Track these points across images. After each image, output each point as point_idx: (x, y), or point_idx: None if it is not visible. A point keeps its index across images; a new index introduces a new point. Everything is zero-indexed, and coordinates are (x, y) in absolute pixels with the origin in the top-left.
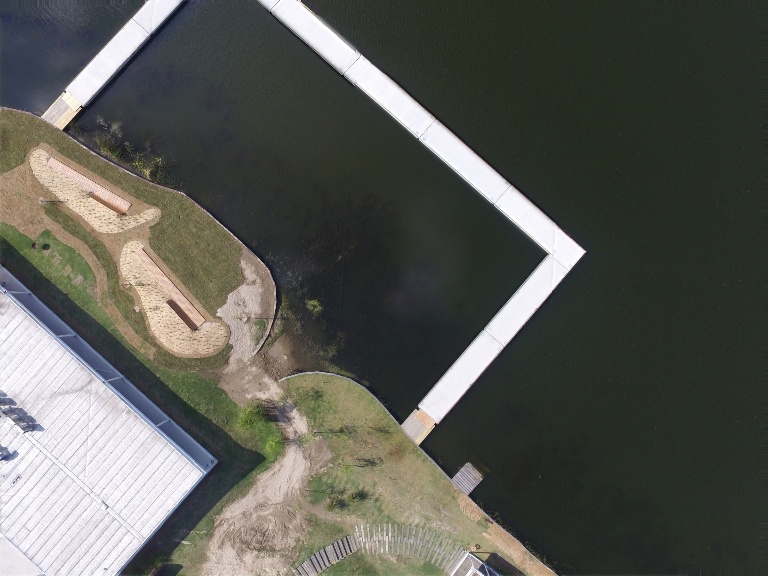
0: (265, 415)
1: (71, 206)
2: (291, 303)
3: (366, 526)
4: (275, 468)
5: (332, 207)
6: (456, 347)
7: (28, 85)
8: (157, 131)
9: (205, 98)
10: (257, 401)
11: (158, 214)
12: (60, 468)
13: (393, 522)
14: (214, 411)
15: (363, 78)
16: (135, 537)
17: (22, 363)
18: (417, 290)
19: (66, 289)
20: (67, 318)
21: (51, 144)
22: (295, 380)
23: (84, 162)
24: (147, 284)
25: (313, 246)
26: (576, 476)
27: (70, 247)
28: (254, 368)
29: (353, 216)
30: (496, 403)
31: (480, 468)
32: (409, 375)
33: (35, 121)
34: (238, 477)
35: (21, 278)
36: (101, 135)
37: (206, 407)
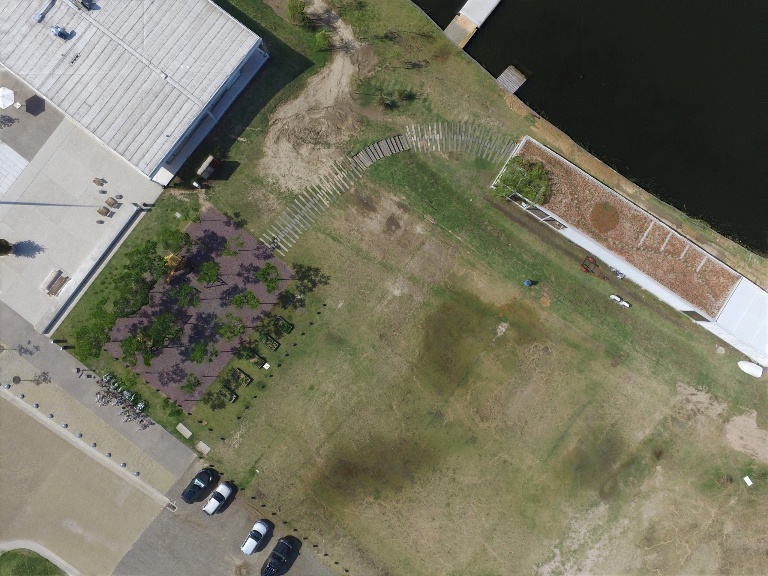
0: (311, 27)
1: None
2: None
3: (417, 126)
4: (324, 73)
5: None
6: None
7: None
8: None
9: None
10: (302, 15)
11: None
12: (118, 43)
13: (443, 120)
14: (262, 18)
15: None
16: (195, 103)
17: None
18: None
19: None
20: None
21: None
22: None
23: None
24: None
25: None
26: (616, 74)
27: None
28: None
29: None
30: (533, 10)
31: (523, 70)
32: None
33: None
34: (289, 76)
35: None
36: None
37: (254, 14)
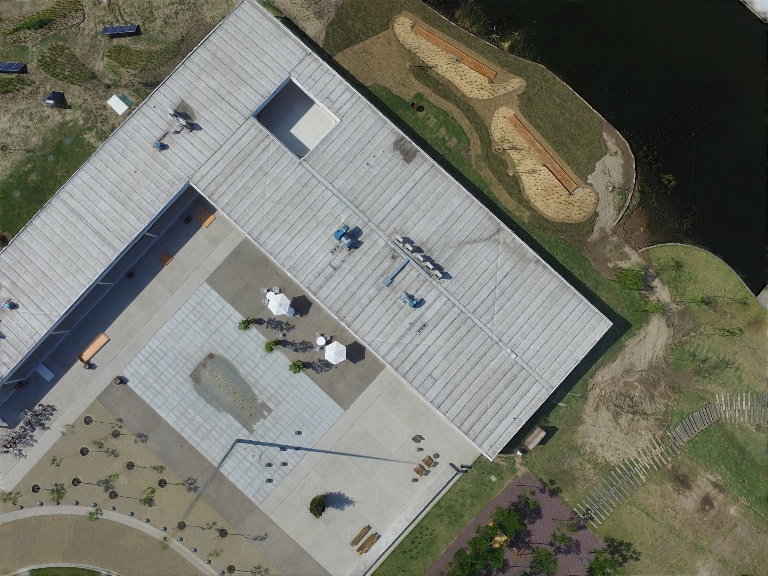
0: None
1: (440, 71)
2: (646, 177)
3: (726, 395)
4: (641, 335)
5: (684, 86)
6: None
7: None
8: (513, 6)
9: None
10: (619, 270)
11: (523, 84)
12: (468, 316)
13: (752, 391)
14: (585, 276)
15: None
16: (544, 387)
17: (429, 211)
18: (765, 169)
19: (441, 151)
20: None
21: (413, 13)
22: (655, 251)
23: (447, 31)
24: (521, 149)
25: (667, 122)
26: None
27: (443, 110)
28: (615, 238)
29: (704, 95)
30: None
31: None
32: (759, 250)
33: None
34: (611, 341)
35: None
36: (468, 4)
37: (578, 271)
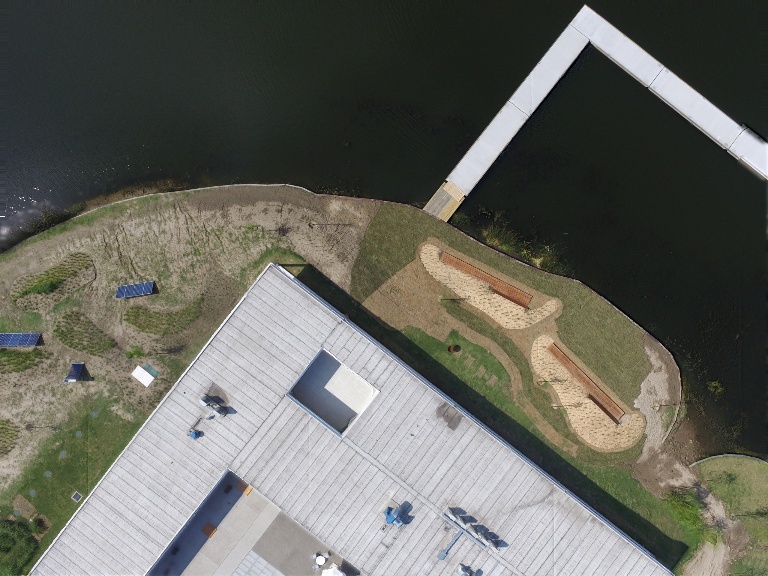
0: None
1: (474, 303)
2: (692, 386)
3: None
4: (697, 555)
5: (726, 285)
6: None
7: (403, 175)
8: (543, 217)
9: (588, 180)
10: (671, 489)
11: (560, 305)
12: None
13: None
14: (638, 504)
15: (749, 152)
16: None
17: (479, 478)
18: None
19: (482, 391)
20: (490, 422)
21: (439, 238)
22: (706, 464)
23: (476, 255)
24: (564, 380)
25: (710, 326)
26: None
27: (481, 347)
28: (664, 455)
29: (747, 293)
30: None
31: None
32: None
33: (417, 214)
34: (669, 569)
35: (437, 383)
36: (497, 227)
37: (631, 501)
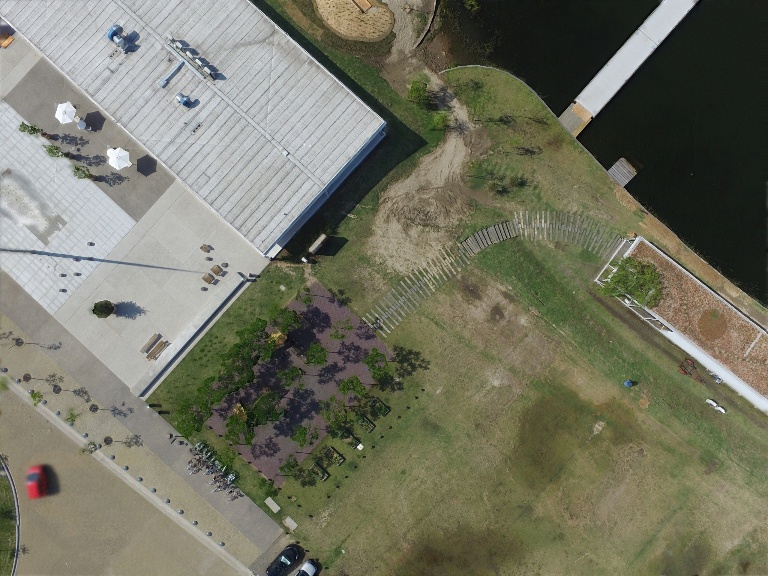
0: (426, 104)
1: None
2: (449, 3)
3: (525, 213)
4: (437, 153)
5: None
6: (609, 49)
7: None
8: None
9: None
10: None
11: None
12: (241, 116)
13: (551, 209)
14: (379, 93)
15: None
16: (315, 183)
17: (205, 15)
18: None
19: None
20: None
21: None
22: (455, 72)
23: None
24: None
25: None
26: (726, 174)
27: None
28: (414, 60)
29: None
30: (648, 103)
31: (634, 164)
32: (564, 74)
33: None
34: (403, 155)
35: None
36: None
37: (371, 88)
